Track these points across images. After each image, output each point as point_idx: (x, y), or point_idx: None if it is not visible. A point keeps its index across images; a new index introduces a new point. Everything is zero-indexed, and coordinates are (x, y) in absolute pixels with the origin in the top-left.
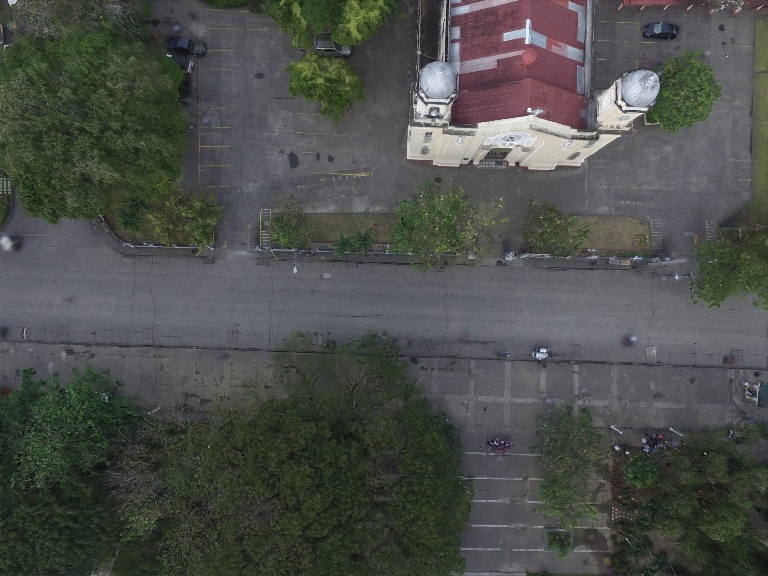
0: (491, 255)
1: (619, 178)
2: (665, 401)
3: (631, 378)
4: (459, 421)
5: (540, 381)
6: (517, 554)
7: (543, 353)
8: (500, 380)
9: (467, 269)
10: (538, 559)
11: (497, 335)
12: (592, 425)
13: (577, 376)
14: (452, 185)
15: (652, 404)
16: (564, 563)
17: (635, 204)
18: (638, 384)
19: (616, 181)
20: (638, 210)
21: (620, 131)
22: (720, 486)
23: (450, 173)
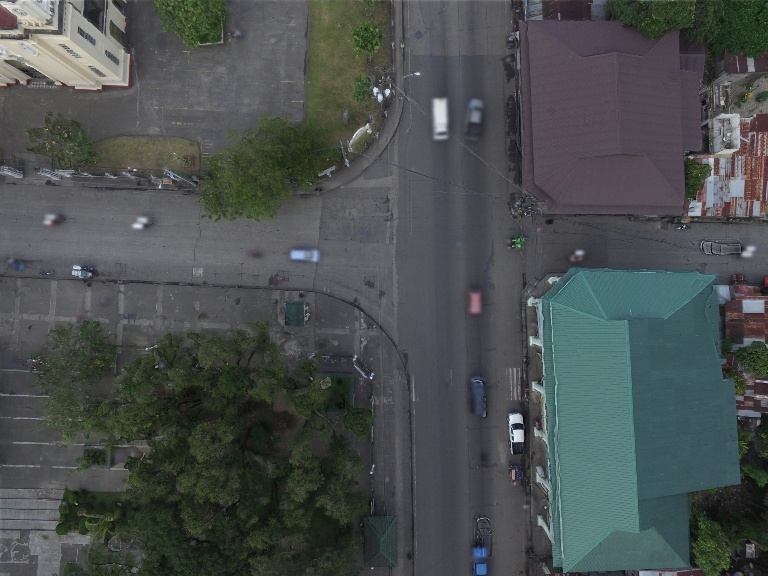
0: (41, 175)
1: (171, 99)
2: (210, 321)
3: (176, 298)
4: (4, 339)
5: (85, 300)
6: (57, 471)
7: (78, 270)
8: (46, 299)
9: (16, 188)
10: (78, 476)
11: (44, 254)
12: (136, 344)
13: (123, 296)
14: (3, 105)
15: (197, 324)
16: (104, 481)
17: (186, 125)
18: (183, 304)
19: (168, 102)
20: (189, 131)
21: (50, 31)
22: (261, 406)
23: (2, 93)
